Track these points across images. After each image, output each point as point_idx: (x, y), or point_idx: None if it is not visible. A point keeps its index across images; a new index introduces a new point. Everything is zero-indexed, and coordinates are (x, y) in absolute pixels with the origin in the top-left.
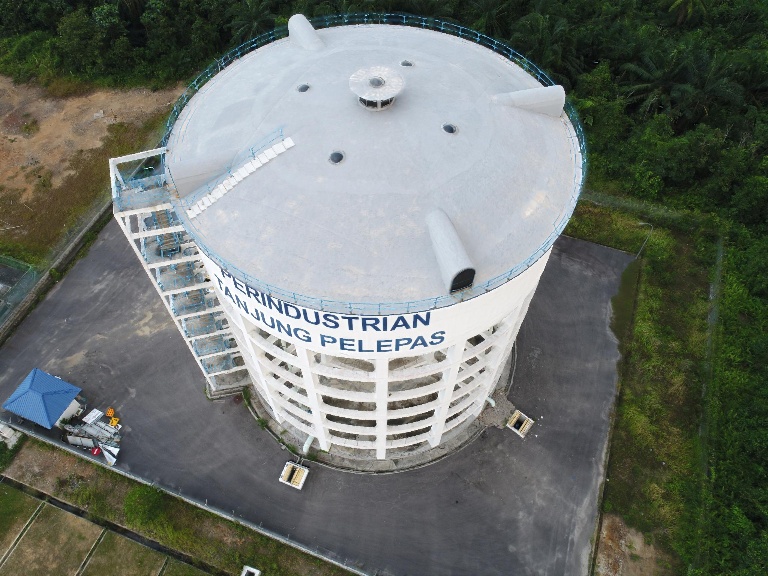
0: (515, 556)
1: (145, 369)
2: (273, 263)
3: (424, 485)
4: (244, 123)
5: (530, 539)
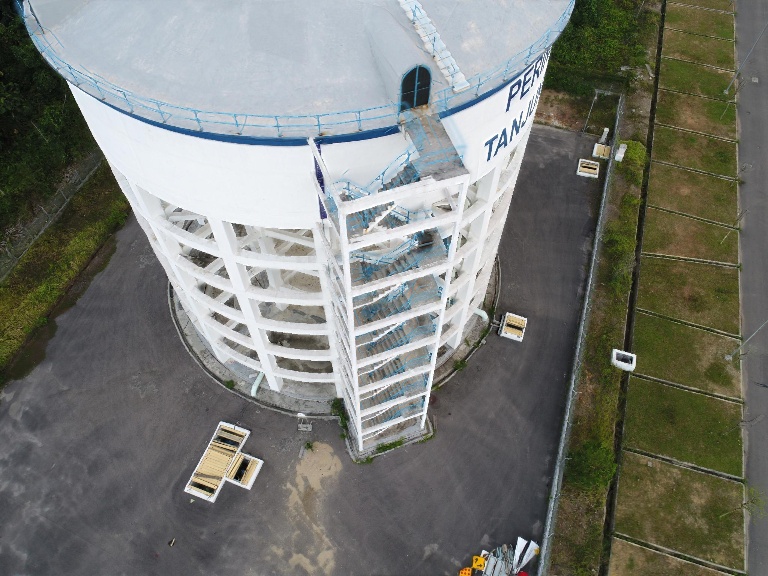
0: (547, 164)
1: (393, 539)
2: (534, 4)
3: None
4: (311, 7)
5: (532, 155)
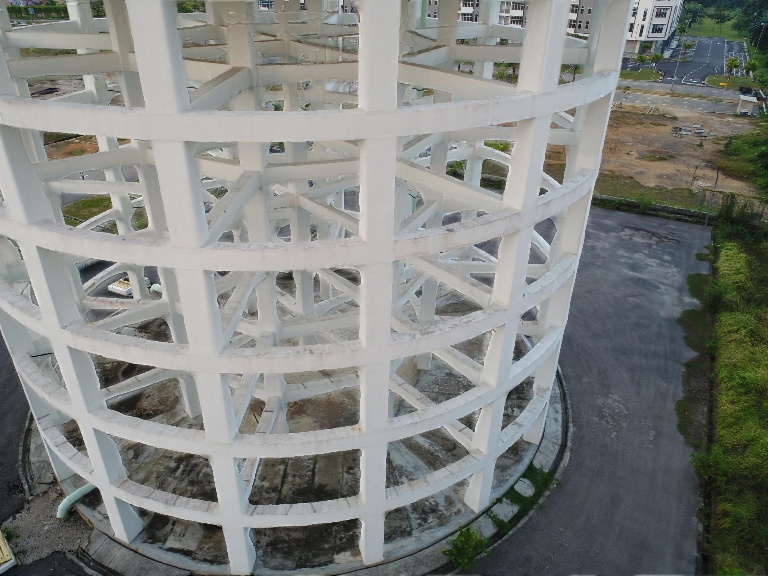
0: None
1: None
2: None
3: (8, 393)
4: None
5: None
